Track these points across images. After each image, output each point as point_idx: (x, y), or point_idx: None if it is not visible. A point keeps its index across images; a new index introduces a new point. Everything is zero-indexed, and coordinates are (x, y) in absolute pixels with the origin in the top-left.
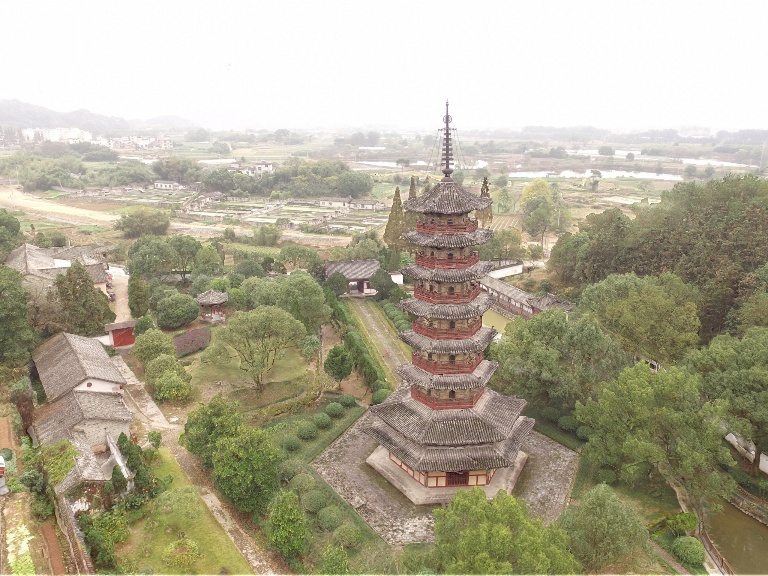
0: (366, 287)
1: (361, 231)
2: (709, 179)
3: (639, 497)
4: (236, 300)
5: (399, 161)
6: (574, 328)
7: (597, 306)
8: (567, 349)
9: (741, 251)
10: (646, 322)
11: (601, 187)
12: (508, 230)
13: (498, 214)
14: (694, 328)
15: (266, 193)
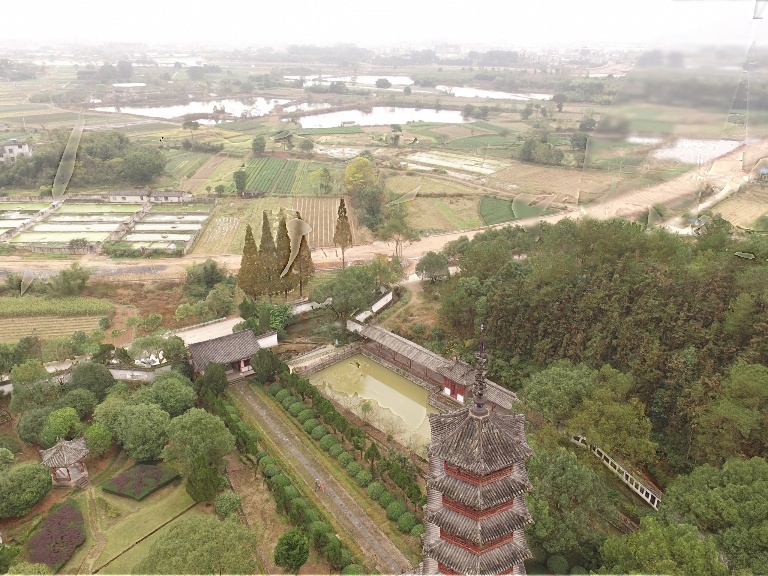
0: (243, 365)
1: (185, 248)
2: (588, 219)
3: None
4: (98, 445)
5: (186, 124)
6: (553, 465)
7: (552, 415)
8: (551, 492)
9: (656, 323)
10: (610, 437)
11: (401, 140)
12: (377, 261)
13: (322, 196)
14: (648, 431)
15: (28, 184)
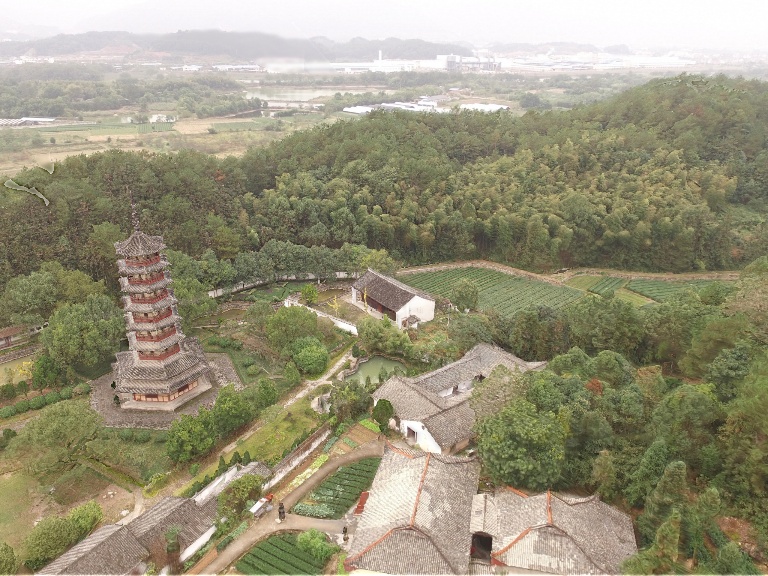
0: None
1: None
2: None
3: (194, 335)
4: None
5: None
6: None
7: None
8: None
9: None
10: None
11: None
12: None
13: None
14: None
15: None
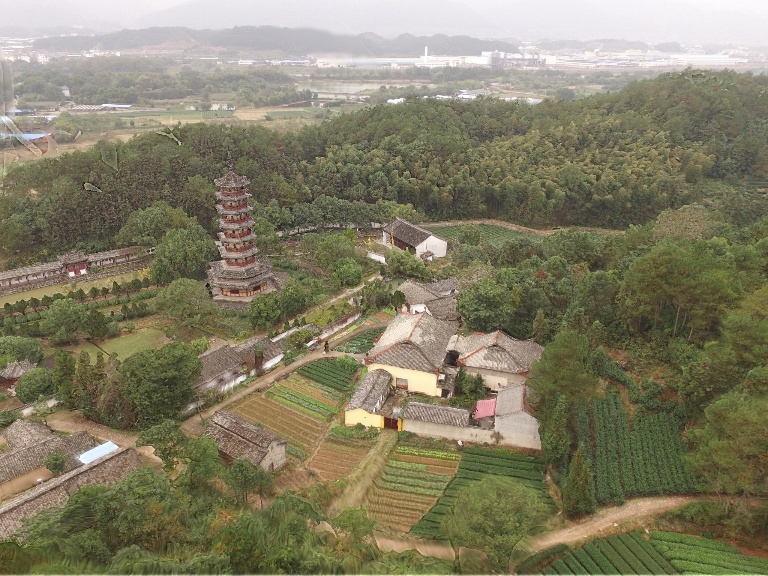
0: None
1: None
2: None
3: None
4: None
5: None
6: None
7: None
8: None
9: None
10: None
11: None
12: None
13: None
14: None
15: None
